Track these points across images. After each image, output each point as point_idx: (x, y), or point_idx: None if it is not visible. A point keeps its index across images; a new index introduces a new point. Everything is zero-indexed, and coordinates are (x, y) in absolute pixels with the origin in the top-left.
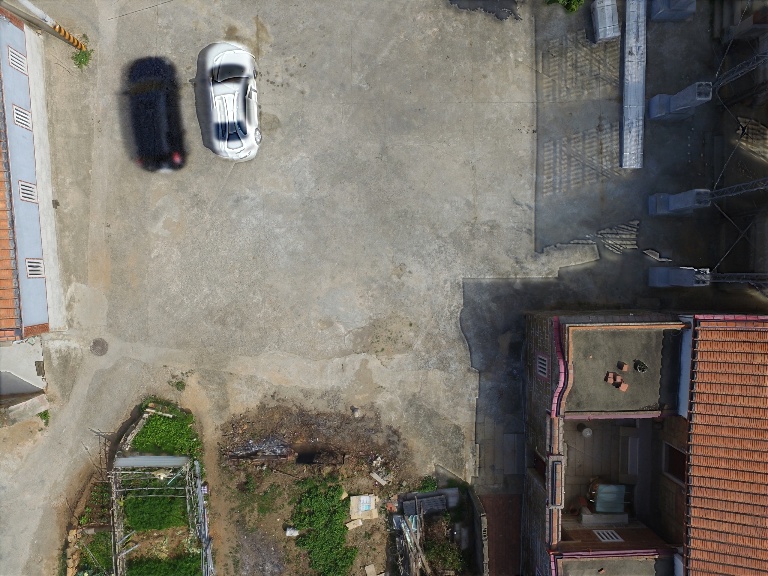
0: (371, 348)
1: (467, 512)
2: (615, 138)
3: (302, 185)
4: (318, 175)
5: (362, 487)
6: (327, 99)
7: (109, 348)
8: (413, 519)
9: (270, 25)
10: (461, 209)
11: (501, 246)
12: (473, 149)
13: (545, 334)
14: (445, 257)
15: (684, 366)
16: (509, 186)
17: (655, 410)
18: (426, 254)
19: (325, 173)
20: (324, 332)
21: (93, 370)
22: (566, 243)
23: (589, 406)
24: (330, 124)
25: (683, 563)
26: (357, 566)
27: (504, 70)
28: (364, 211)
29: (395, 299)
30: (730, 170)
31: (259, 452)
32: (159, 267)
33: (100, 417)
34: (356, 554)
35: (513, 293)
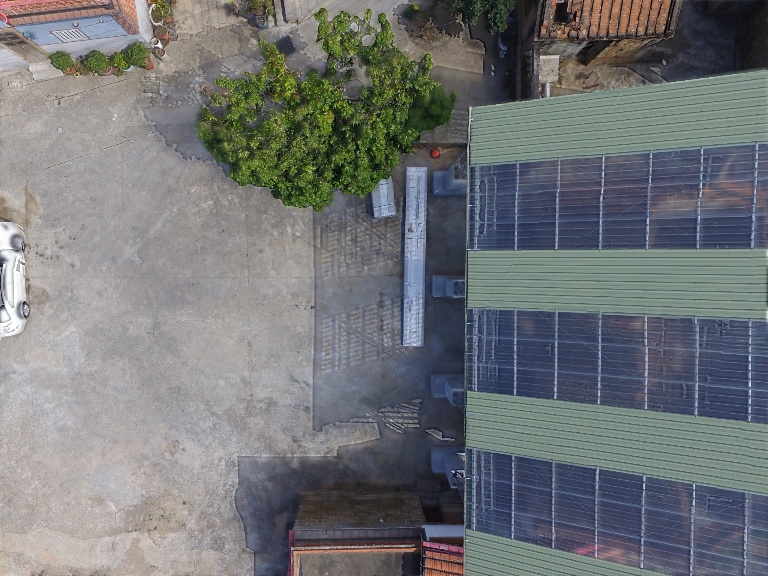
0: (143, 526)
1: None
2: (396, 315)
3: (71, 360)
4: (88, 350)
5: None
6: (98, 273)
7: None
8: None
9: (39, 196)
10: (236, 386)
11: (278, 424)
12: (249, 325)
13: None
14: (220, 435)
15: None
16: (286, 363)
17: None
18: (200, 431)
19: (95, 348)
20: (94, 510)
21: None
22: (345, 421)
23: None
24: (100, 298)
25: None
26: None
27: (281, 245)
28: (136, 387)
29: (168, 477)
30: None
31: None
32: None
33: None
34: None
35: (290, 472)
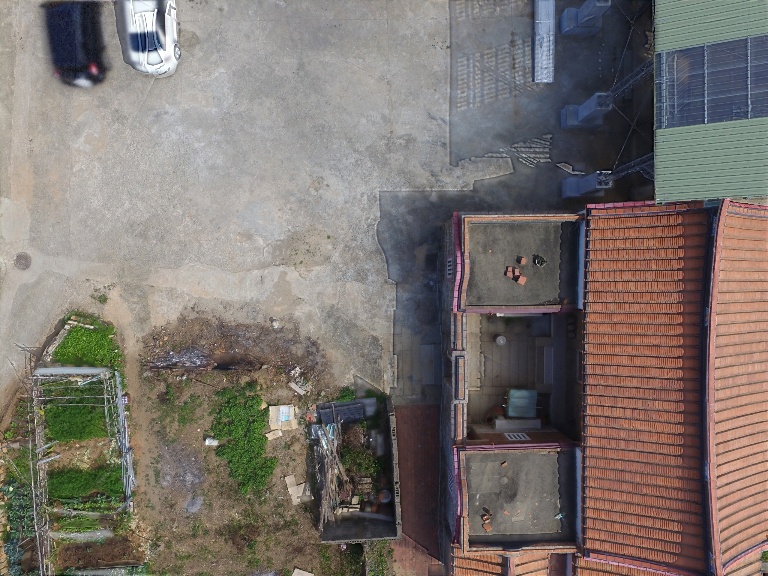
0: (290, 260)
1: (383, 419)
2: (527, 54)
3: (220, 100)
4: (236, 90)
5: (282, 398)
6: (245, 16)
7: (32, 262)
8: (331, 428)
9: None
10: (377, 123)
11: (417, 160)
12: (388, 65)
13: (450, 235)
14: (362, 170)
15: (581, 259)
16: (424, 101)
17: (555, 304)
18: (343, 168)
19: (243, 88)
20: (243, 245)
21: (17, 284)
22: (480, 157)
23: (490, 300)
24: (248, 40)
25: (581, 452)
26: (277, 477)
27: None
28: (282, 126)
29: (313, 212)
30: (639, 83)
31: (179, 363)
32: (81, 181)
33: (25, 332)
34: (276, 464)
35: (429, 206)
